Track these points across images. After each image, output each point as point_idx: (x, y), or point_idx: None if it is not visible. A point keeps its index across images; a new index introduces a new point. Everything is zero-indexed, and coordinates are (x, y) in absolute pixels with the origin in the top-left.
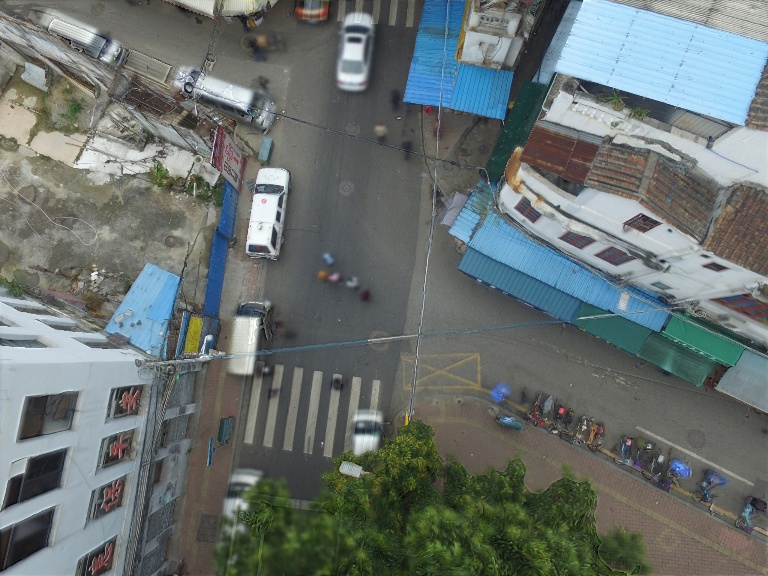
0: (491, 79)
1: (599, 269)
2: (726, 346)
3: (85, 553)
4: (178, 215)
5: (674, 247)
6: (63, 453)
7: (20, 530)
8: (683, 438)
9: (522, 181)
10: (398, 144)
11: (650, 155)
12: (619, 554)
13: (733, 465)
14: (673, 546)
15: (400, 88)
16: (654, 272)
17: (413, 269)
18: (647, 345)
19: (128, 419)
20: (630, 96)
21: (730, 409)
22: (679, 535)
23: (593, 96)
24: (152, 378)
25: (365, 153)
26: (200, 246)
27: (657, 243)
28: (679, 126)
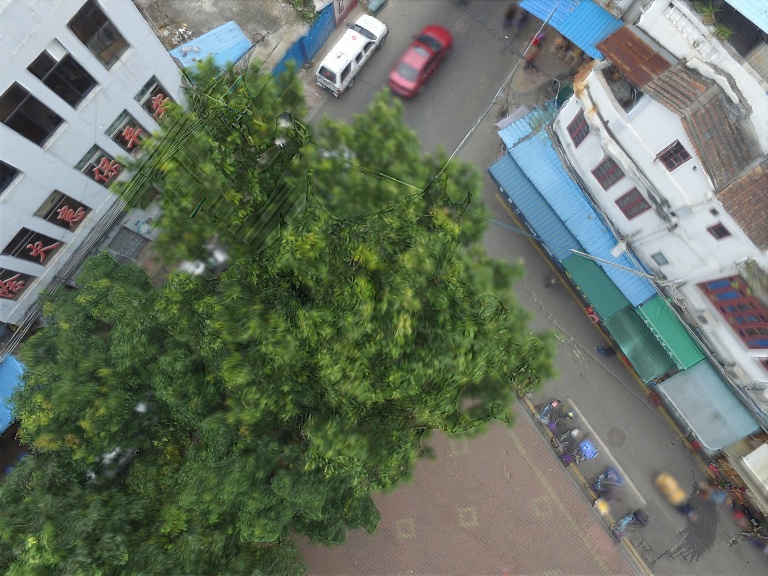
0: (607, 23)
1: (612, 222)
2: (688, 348)
3: (63, 191)
4: (276, 20)
5: (690, 196)
6: (92, 85)
7: (30, 108)
8: (605, 430)
9: (587, 86)
10: (494, 58)
11: (713, 86)
12: (493, 492)
13: (637, 476)
14: (544, 513)
15: (522, 13)
16: (660, 231)
17: (448, 166)
18: (618, 320)
19: (152, 119)
20: (723, 8)
21: (661, 429)
22: (555, 507)
23: (691, 3)
24: (187, 106)
25: (461, 51)
26: (280, 55)
27: (677, 187)
28: (753, 64)
